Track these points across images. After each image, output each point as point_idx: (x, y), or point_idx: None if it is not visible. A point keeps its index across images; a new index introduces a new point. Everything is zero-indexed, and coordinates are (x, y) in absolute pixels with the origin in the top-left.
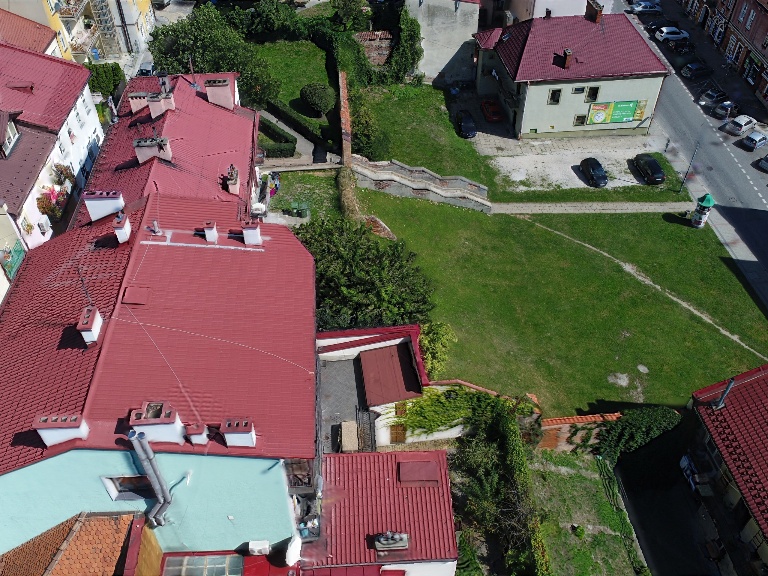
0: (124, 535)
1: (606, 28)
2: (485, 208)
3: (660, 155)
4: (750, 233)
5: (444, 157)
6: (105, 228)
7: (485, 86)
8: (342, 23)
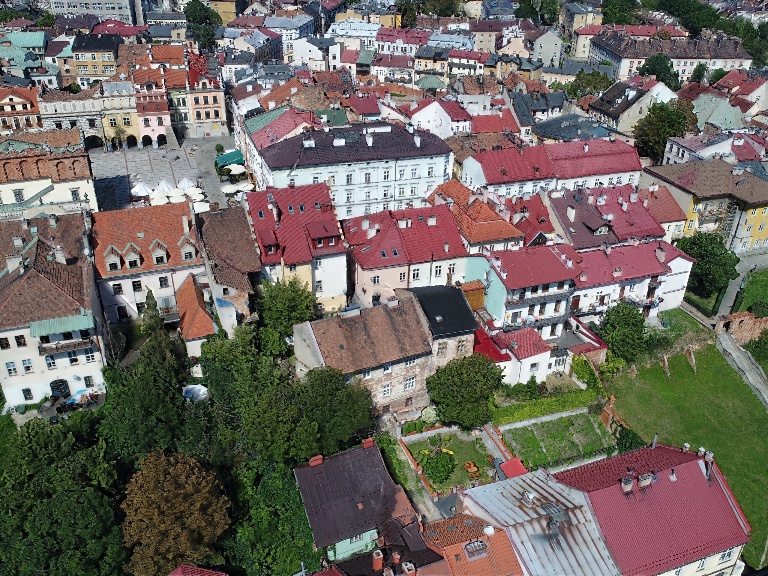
0: None
1: None
2: (767, 406)
3: None
4: None
5: None
6: None
7: None
8: None
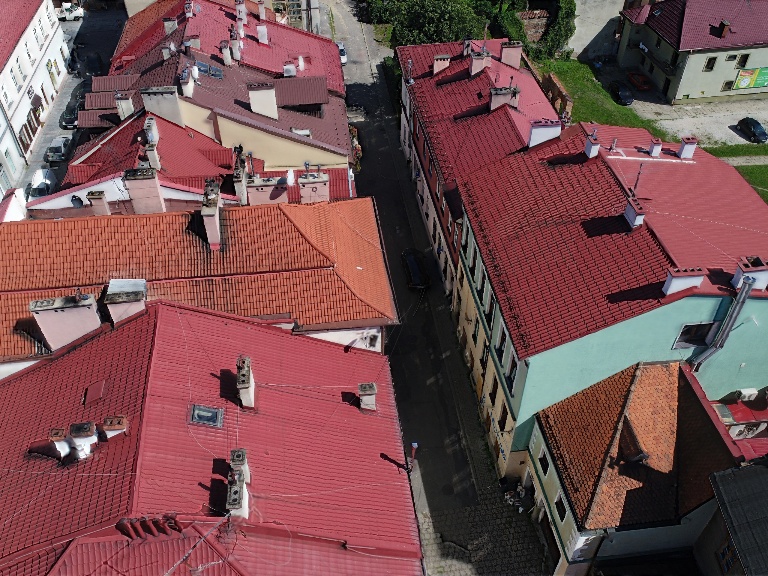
0: (677, 378)
1: (751, 1)
2: None
3: None
4: None
5: (618, 121)
6: (548, 151)
7: (628, 59)
8: (494, 5)
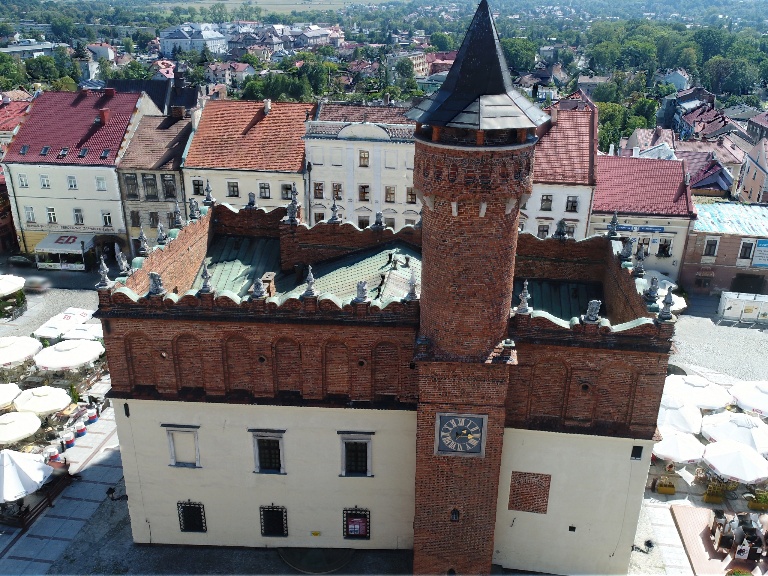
0: None
1: None
2: None
3: None
4: None
5: None
6: None
7: None
8: None
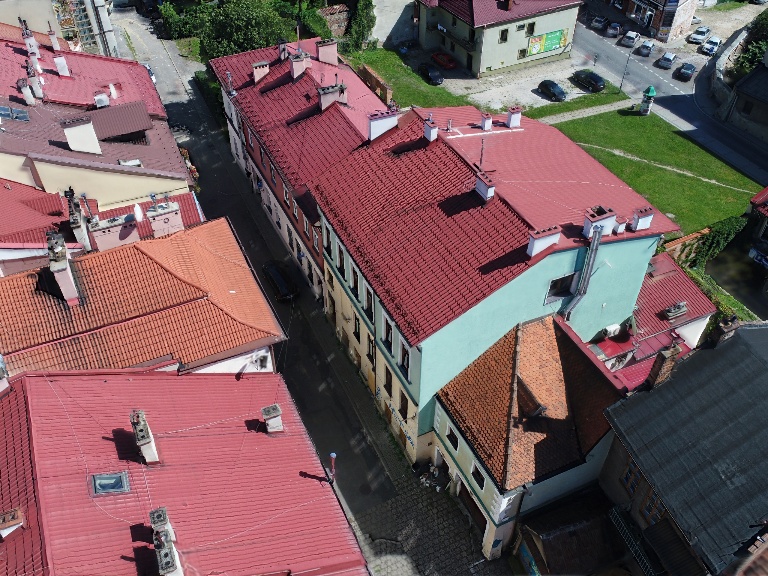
0: (553, 330)
1: None
2: None
3: (589, 70)
4: (681, 112)
5: (434, 101)
6: (390, 141)
7: (430, 41)
8: (293, 5)
